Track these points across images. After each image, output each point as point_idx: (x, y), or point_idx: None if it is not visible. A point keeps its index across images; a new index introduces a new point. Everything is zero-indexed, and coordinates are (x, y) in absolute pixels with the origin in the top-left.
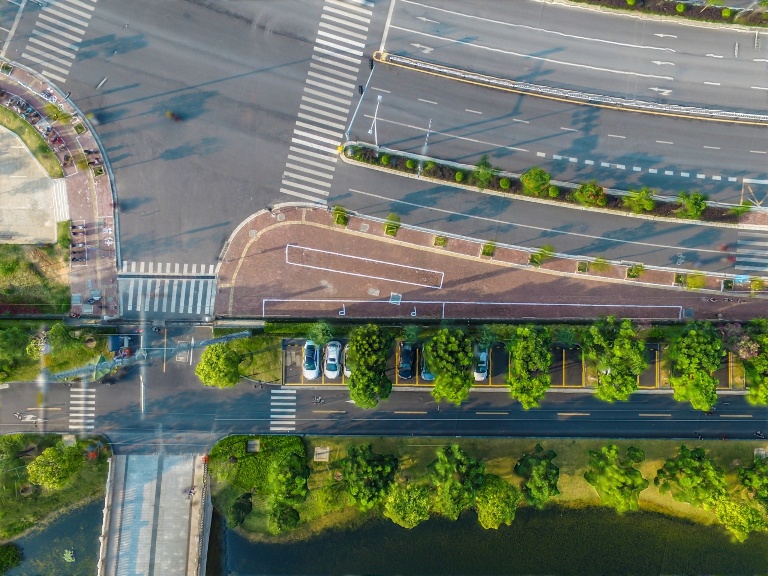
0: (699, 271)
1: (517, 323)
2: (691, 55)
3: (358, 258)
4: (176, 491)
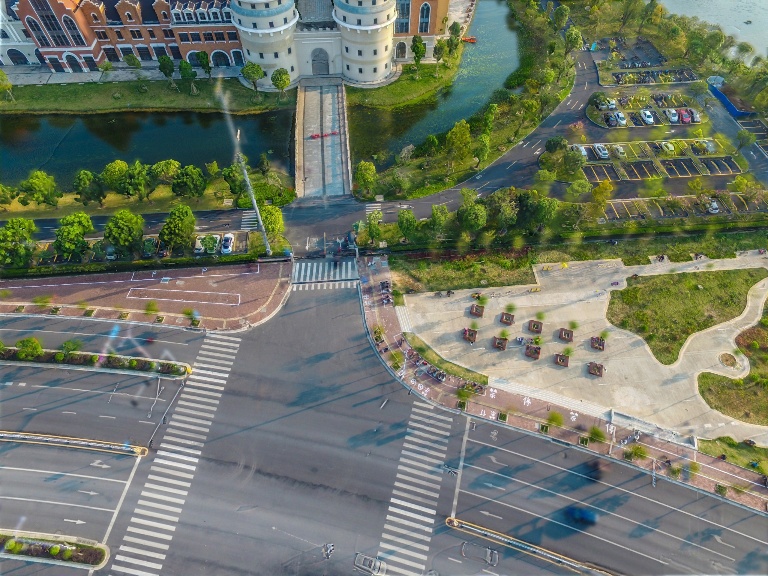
0: None
1: (82, 272)
2: None
3: (188, 301)
4: (314, 181)
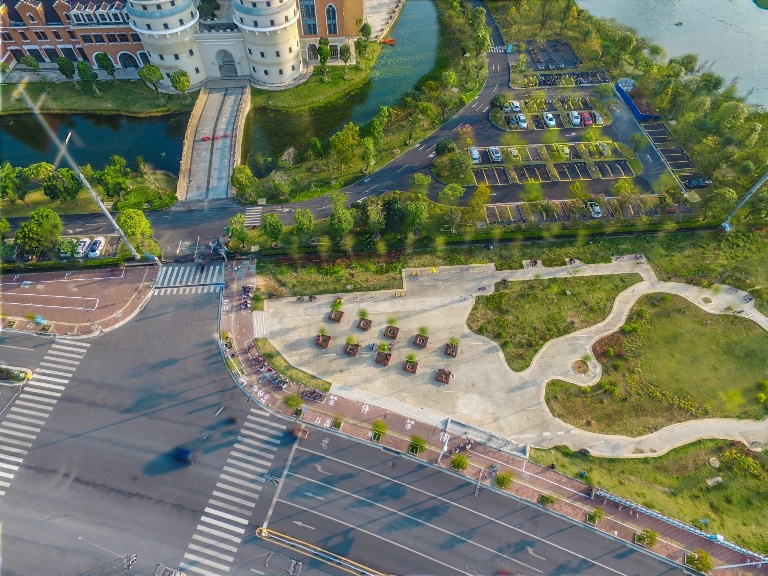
0: None
1: None
2: None
3: (44, 306)
4: (198, 183)
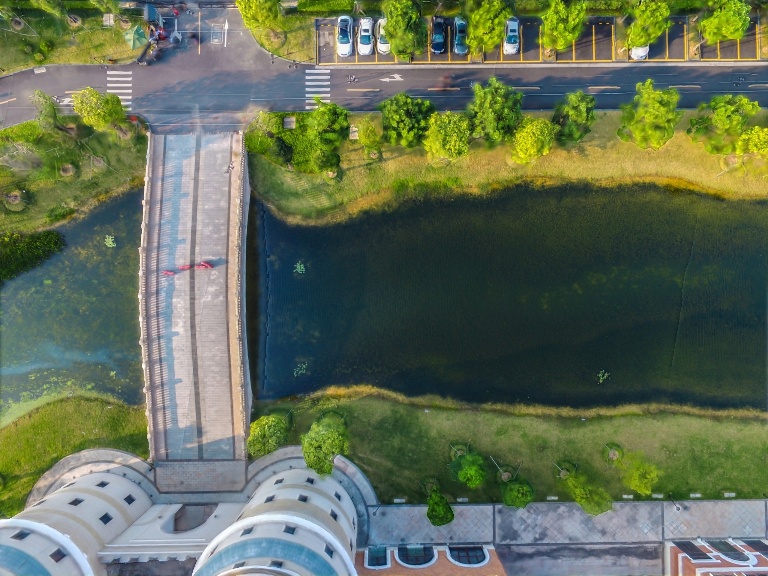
0: None
1: None
2: None
3: None
4: (215, 166)
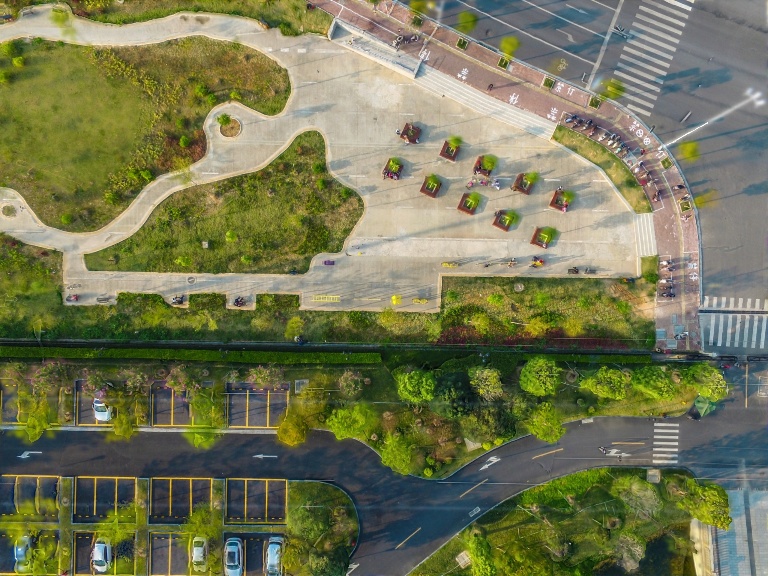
0: None
1: None
2: None
3: None
4: (767, 526)
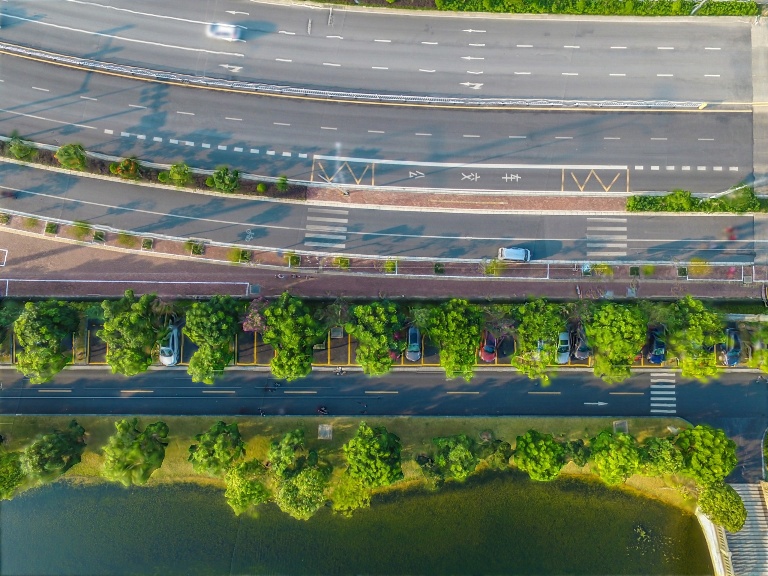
0: (268, 247)
1: (80, 300)
2: (263, 32)
3: None
4: None
